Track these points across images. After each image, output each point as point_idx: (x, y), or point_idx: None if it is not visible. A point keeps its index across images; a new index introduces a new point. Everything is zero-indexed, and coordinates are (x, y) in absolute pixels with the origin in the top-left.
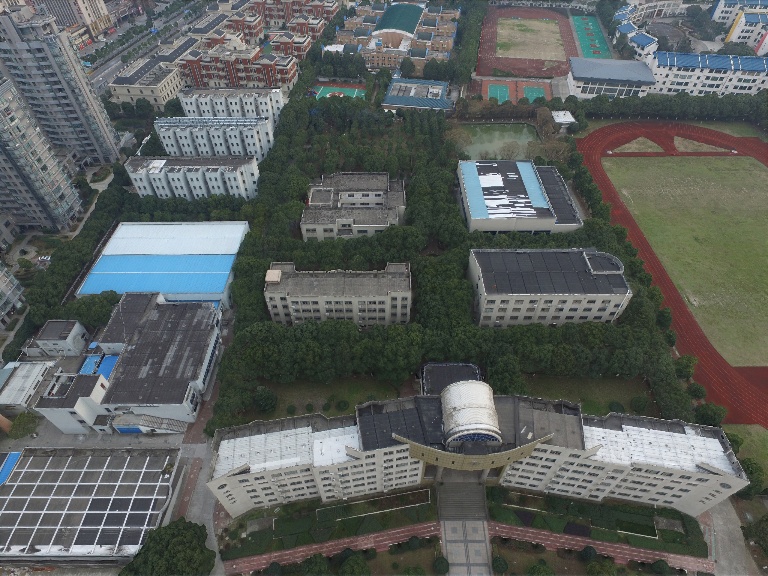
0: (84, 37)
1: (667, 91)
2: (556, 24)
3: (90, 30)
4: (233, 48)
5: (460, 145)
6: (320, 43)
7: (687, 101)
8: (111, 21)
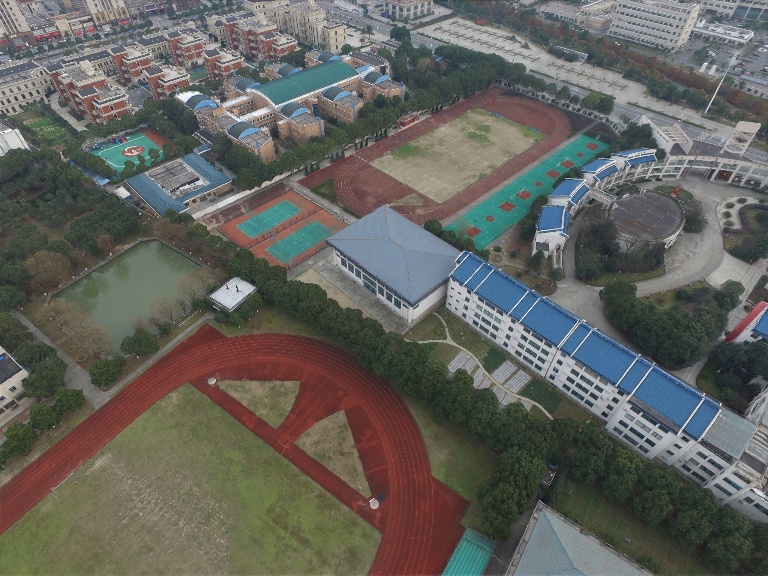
0: (87, 24)
1: (473, 322)
2: (534, 141)
3: (94, 19)
4: (84, 70)
5: (29, 276)
6: (180, 87)
7: (398, 364)
8: (127, 13)
